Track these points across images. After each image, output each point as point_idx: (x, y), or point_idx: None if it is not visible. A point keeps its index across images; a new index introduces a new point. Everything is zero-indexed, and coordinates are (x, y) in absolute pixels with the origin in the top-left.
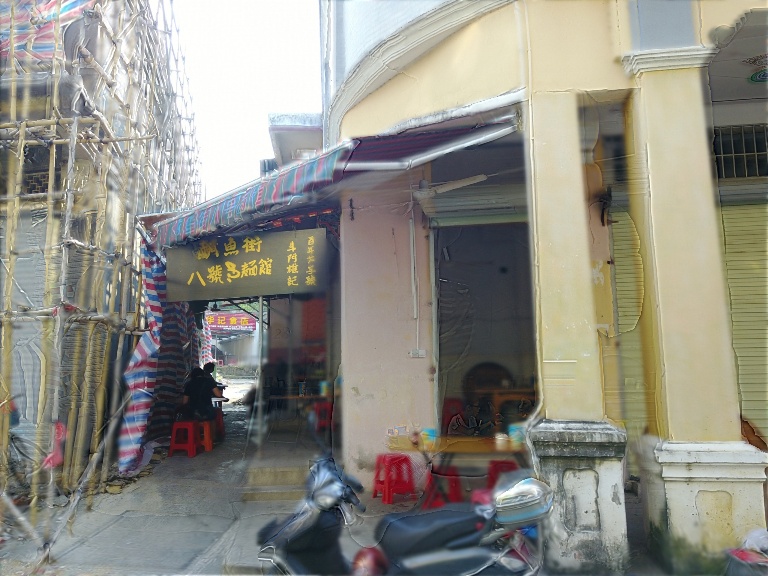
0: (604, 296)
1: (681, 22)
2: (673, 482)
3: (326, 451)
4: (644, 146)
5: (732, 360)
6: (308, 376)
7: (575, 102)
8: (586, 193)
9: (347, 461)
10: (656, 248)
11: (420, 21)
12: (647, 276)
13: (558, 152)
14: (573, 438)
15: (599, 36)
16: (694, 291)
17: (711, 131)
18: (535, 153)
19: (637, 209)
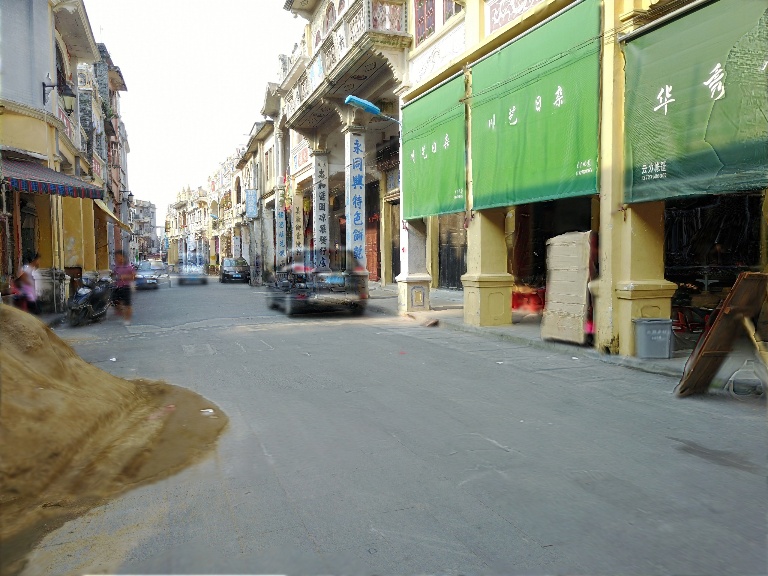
0: None
1: None
2: None
3: None
4: None
5: None
6: None
7: None
8: None
9: None
10: None
11: None
12: (57, 226)
13: None
14: None
15: None
16: None
17: None
18: None
19: None
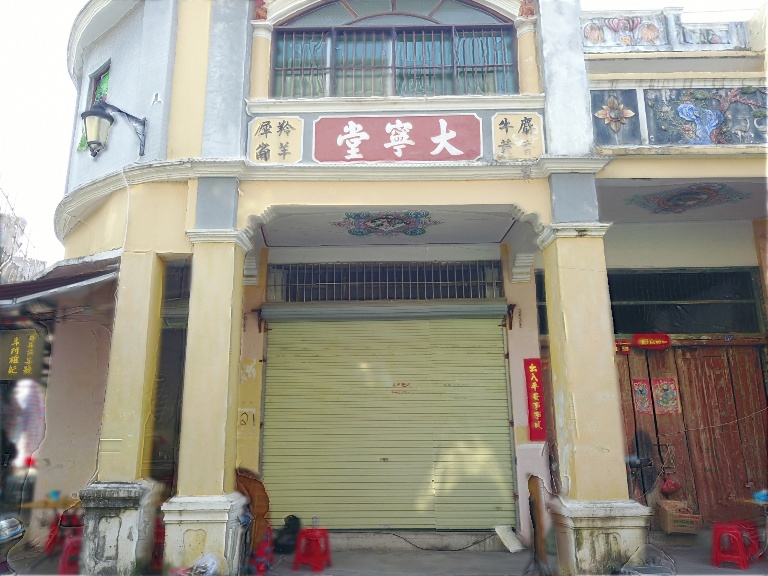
0: (254, 387)
1: (221, 212)
2: (171, 524)
3: (15, 512)
4: (188, 293)
5: (223, 439)
6: (13, 449)
7: (148, 260)
8: (146, 323)
9: (32, 520)
10: (186, 362)
11: (78, 189)
12: None
13: (132, 294)
14: (106, 494)
15: (174, 216)
16: (205, 392)
17: (231, 285)
18: (117, 294)
19: (178, 335)
